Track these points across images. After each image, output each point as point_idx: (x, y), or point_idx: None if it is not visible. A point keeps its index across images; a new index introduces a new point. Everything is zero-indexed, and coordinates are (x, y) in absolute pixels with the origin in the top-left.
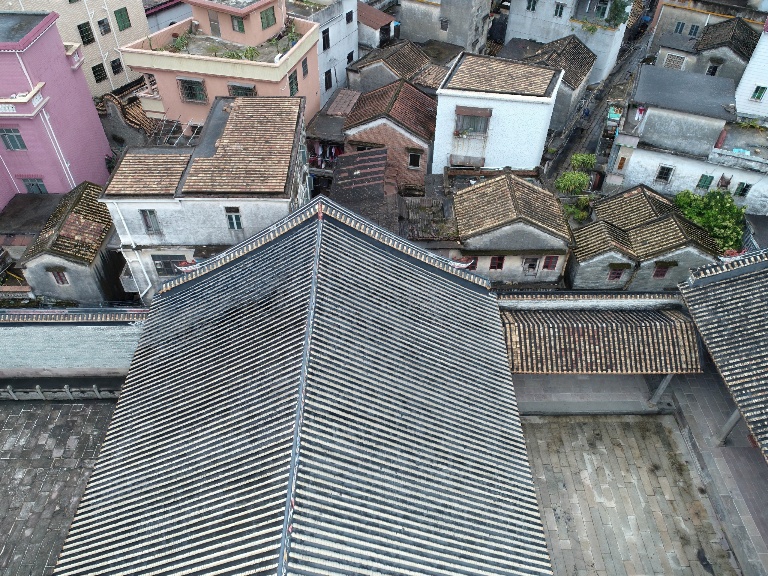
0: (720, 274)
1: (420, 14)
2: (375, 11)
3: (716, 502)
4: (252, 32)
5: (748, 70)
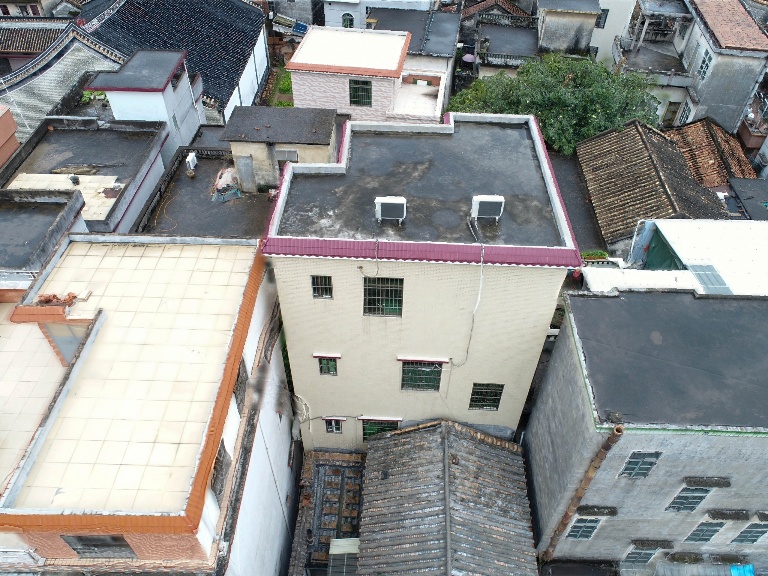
0: (93, 2)
1: None
2: None
3: None
4: None
5: None
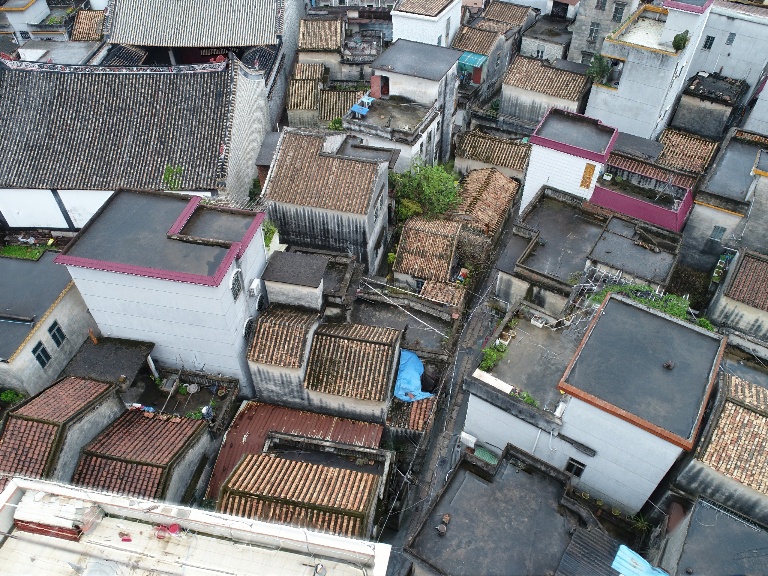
0: None
1: None
2: None
3: None
4: None
5: None
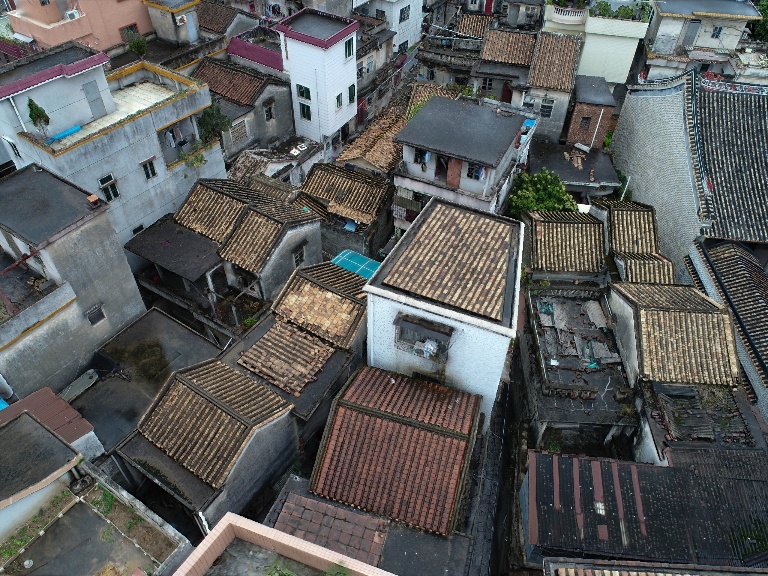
0: None
1: (44, 343)
2: (0, 421)
3: None
4: None
5: (327, 89)
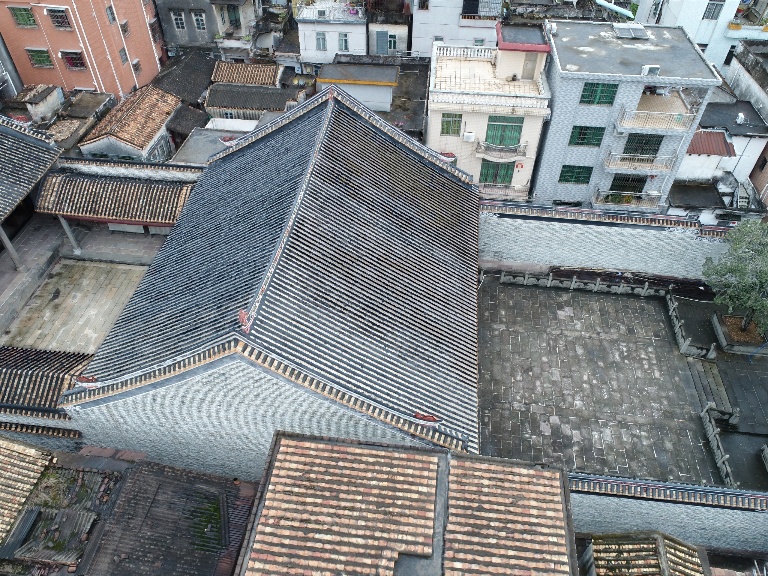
0: None
1: None
2: None
3: (8, 320)
4: None
5: None
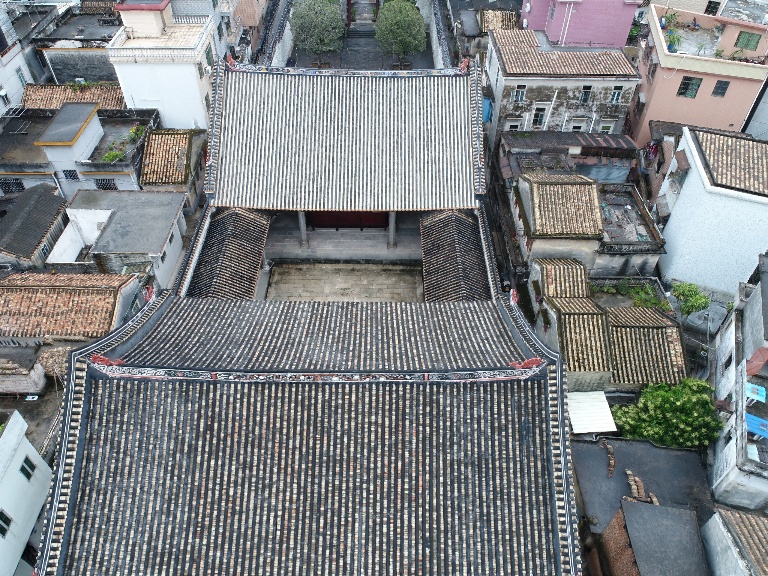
0: None
1: None
2: None
3: None
4: (721, 41)
5: None
